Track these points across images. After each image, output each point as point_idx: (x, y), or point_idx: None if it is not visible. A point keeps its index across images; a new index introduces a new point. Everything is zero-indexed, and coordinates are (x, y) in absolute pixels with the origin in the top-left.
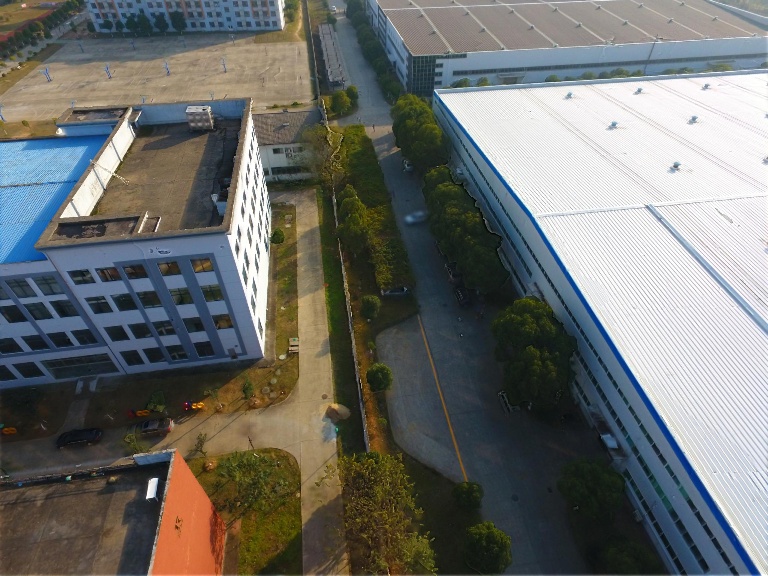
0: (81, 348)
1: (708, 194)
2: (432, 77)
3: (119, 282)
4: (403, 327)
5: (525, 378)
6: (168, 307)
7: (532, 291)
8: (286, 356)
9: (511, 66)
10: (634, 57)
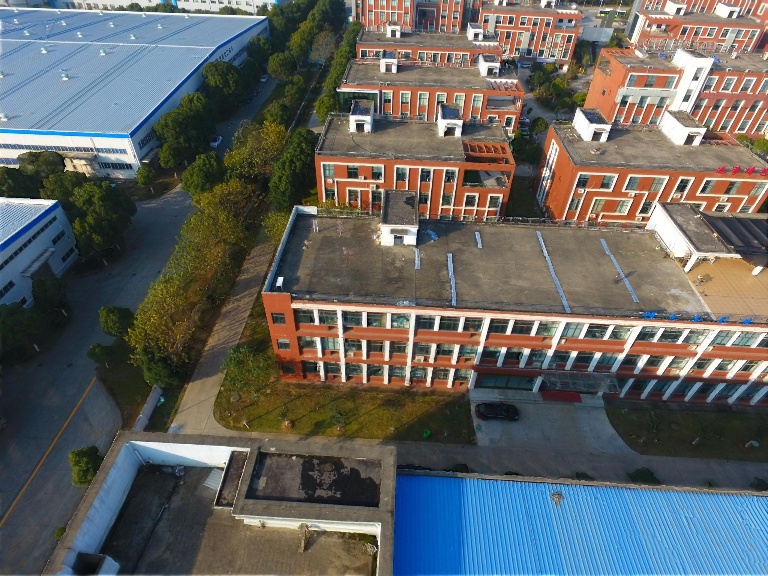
0: None
1: None
2: None
3: None
4: None
5: None
6: None
7: None
8: None
9: None
10: None
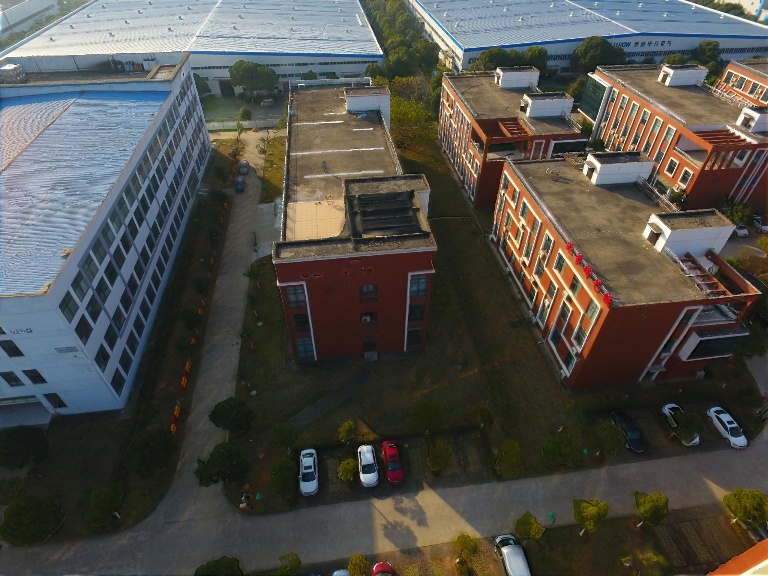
0: None
1: None
2: None
3: None
4: None
5: (269, 75)
6: None
7: (219, 79)
8: (215, 142)
9: None
10: (1, 26)
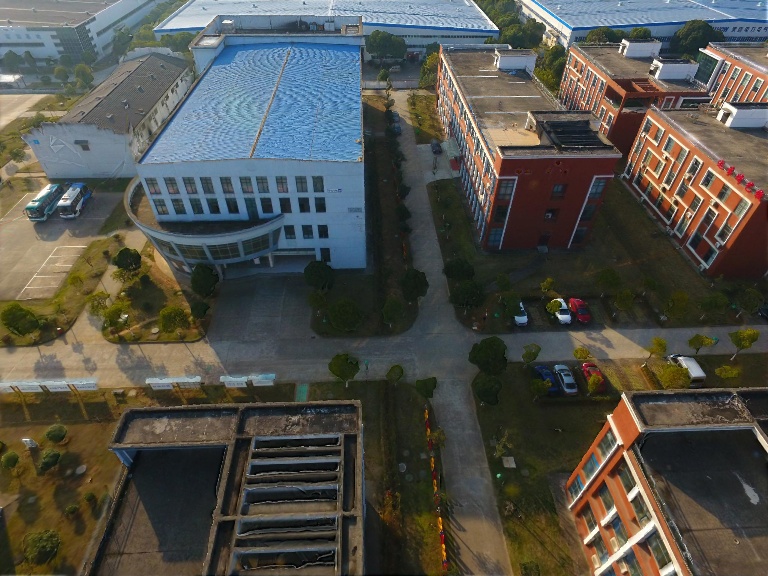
0: None
1: (328, 3)
2: (90, 42)
3: None
4: None
5: (401, 44)
6: None
7: None
8: None
9: (114, 20)
10: None
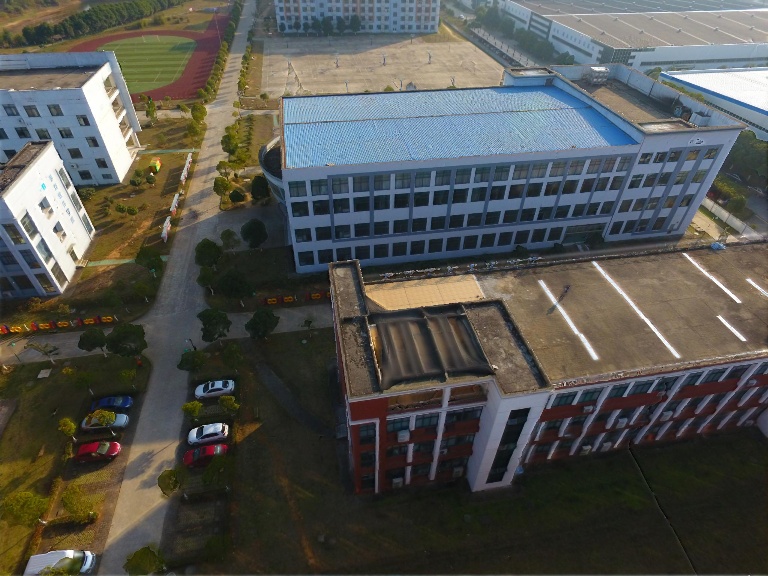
0: (597, 217)
1: None
2: None
3: (660, 164)
4: (752, 221)
5: None
6: (668, 186)
7: None
8: (698, 233)
9: (684, 59)
10: None
